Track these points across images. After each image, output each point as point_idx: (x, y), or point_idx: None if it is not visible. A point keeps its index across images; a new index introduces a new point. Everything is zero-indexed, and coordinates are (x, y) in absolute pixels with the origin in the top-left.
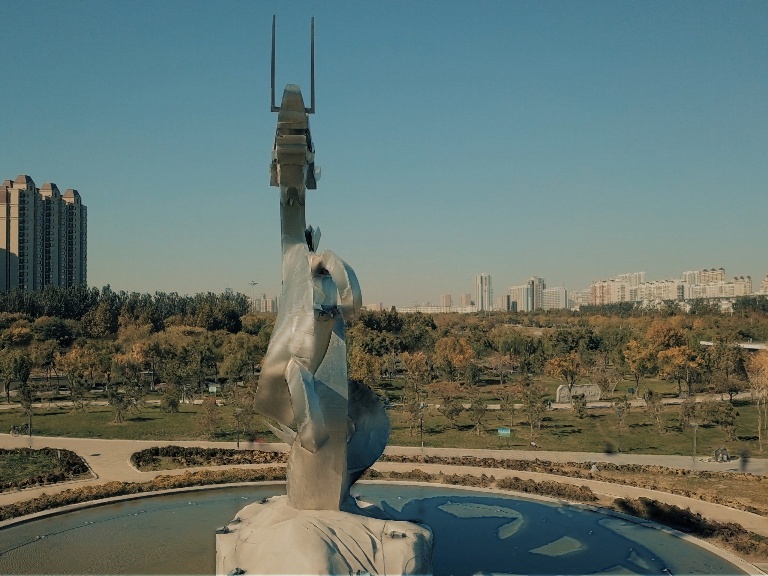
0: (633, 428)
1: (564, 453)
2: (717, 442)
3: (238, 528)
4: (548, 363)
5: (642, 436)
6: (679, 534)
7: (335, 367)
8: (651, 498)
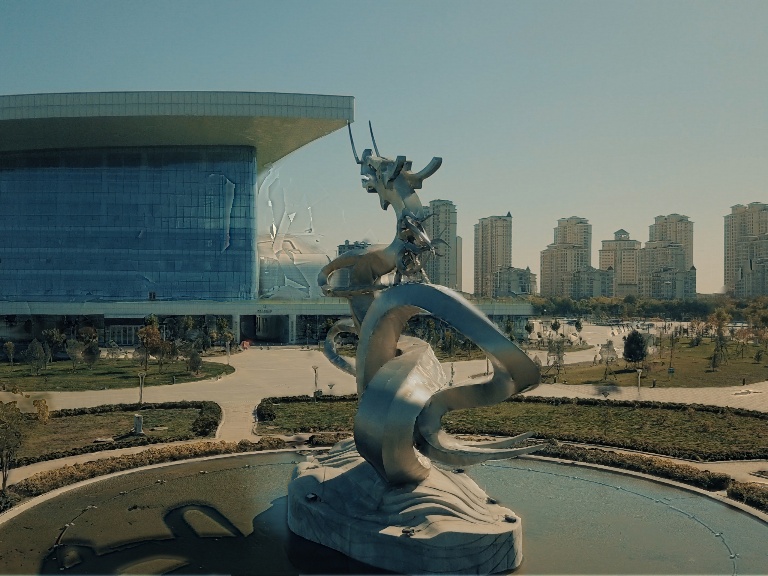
0: None
1: None
2: None
3: None
4: None
5: None
6: None
7: None
8: None
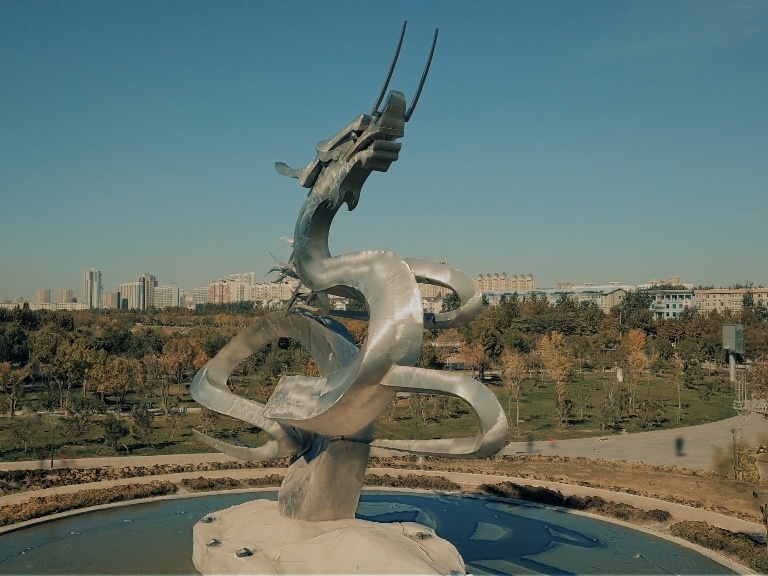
0: (400, 421)
1: (373, 448)
2: (477, 430)
3: (257, 549)
4: (309, 363)
5: (416, 428)
6: (564, 509)
7: None
8: (499, 482)
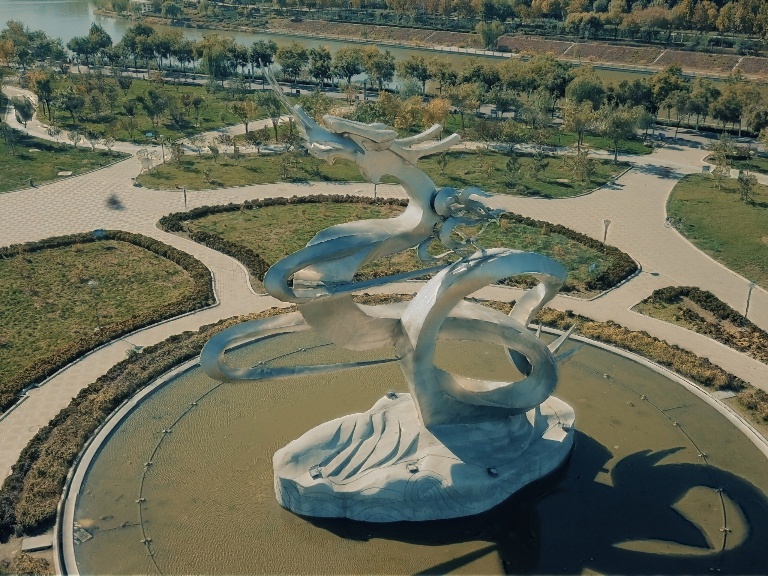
0: None
1: None
2: None
3: (399, 399)
4: None
5: None
6: None
7: (417, 320)
8: None
